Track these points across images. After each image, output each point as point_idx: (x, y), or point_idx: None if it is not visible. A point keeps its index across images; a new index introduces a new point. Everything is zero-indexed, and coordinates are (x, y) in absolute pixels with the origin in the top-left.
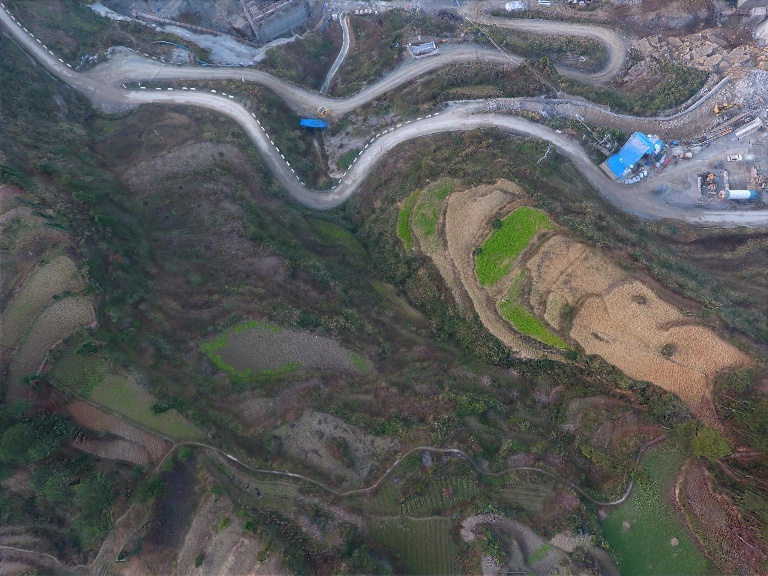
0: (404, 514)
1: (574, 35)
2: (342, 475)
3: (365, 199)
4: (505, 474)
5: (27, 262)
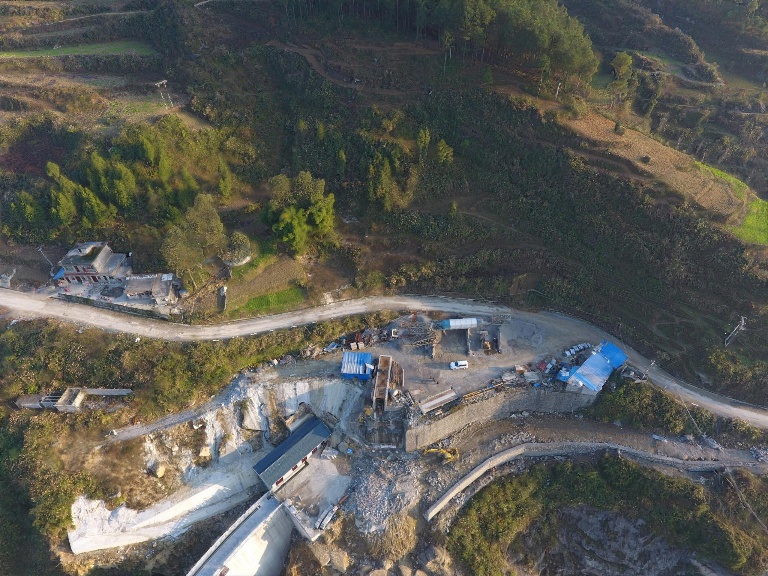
0: None
1: None
2: None
3: None
4: None
5: None
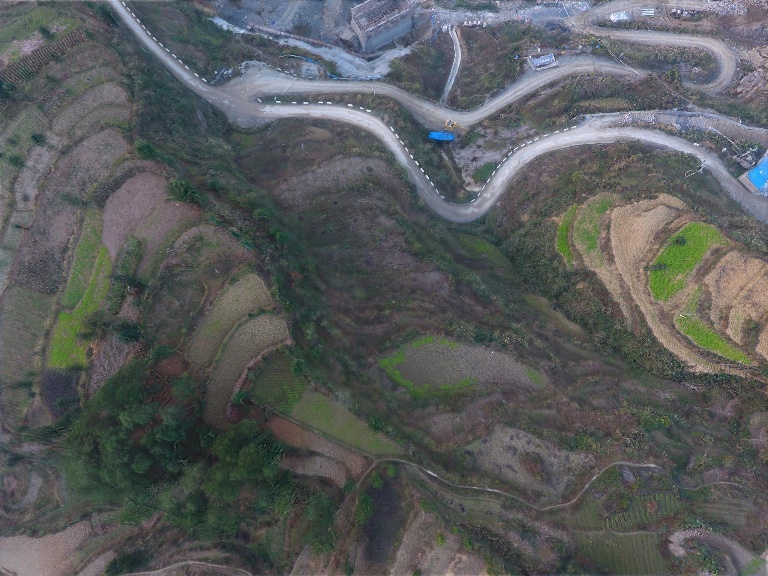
0: (608, 529)
1: (683, 46)
2: (539, 490)
3: (509, 212)
4: (704, 489)
5: (214, 280)
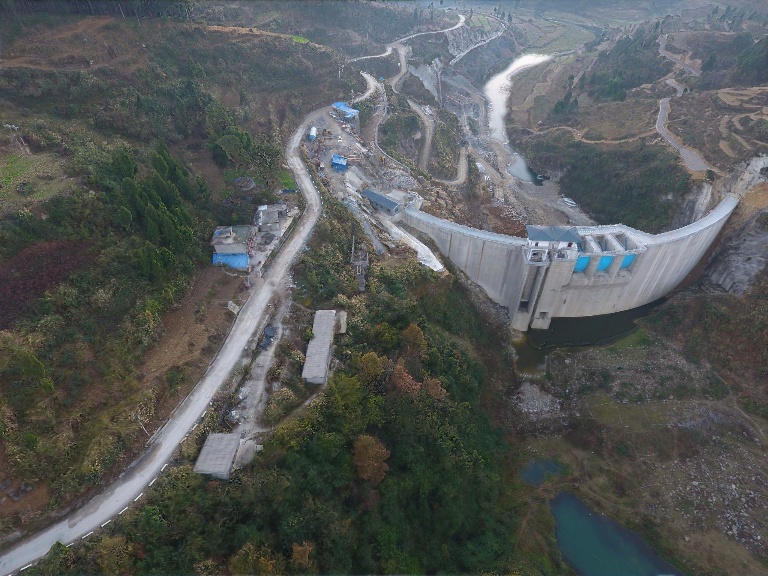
0: None
1: None
2: None
3: None
4: None
5: None
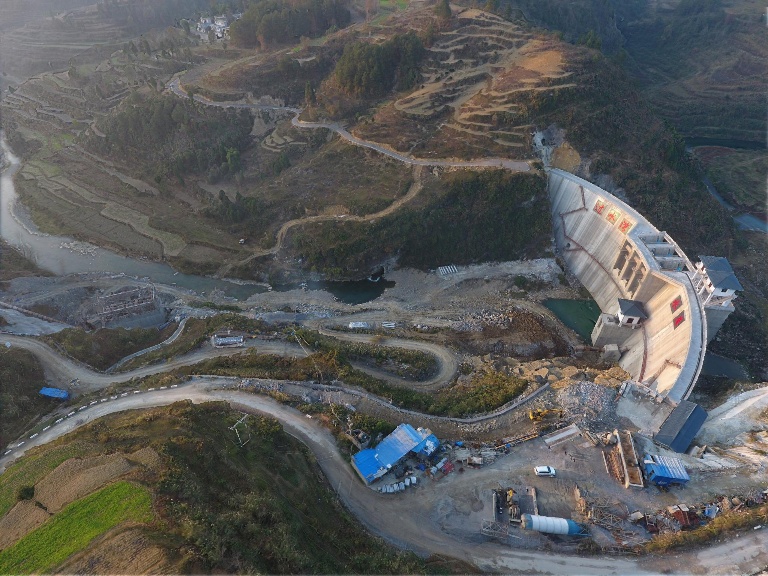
0: None
1: None
2: None
3: None
4: None
5: None
